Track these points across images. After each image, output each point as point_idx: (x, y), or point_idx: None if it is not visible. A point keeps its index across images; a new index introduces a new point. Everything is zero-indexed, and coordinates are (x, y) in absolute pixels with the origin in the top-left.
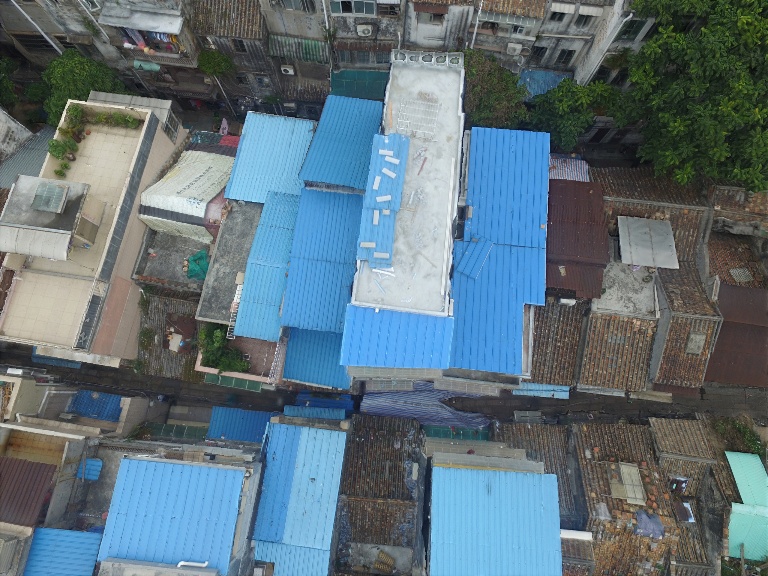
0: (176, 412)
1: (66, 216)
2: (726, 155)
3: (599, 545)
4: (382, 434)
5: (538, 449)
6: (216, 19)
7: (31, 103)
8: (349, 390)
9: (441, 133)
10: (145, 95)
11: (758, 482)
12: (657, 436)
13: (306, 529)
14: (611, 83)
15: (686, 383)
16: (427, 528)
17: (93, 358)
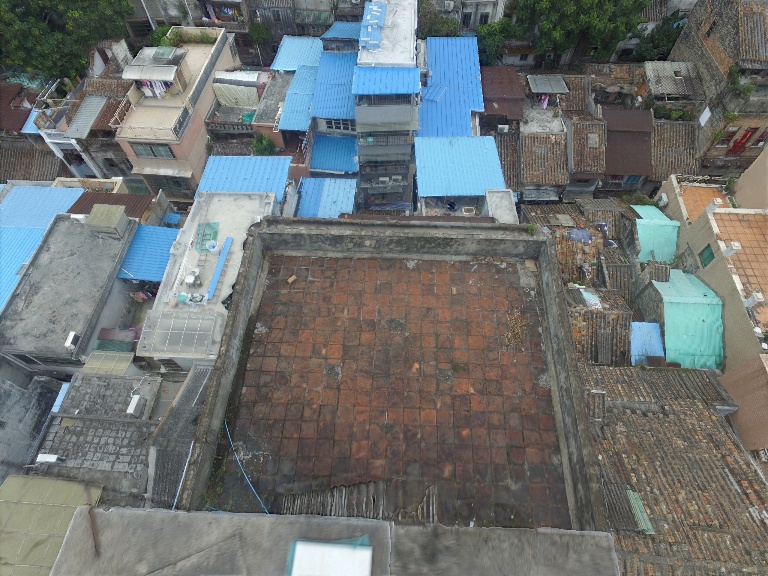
0: None
1: (174, 61)
2: (573, 7)
3: None
4: None
5: None
6: None
7: None
8: None
9: (405, 2)
10: None
11: (654, 213)
12: (581, 204)
13: None
14: None
15: (594, 169)
16: (416, 200)
17: (173, 172)
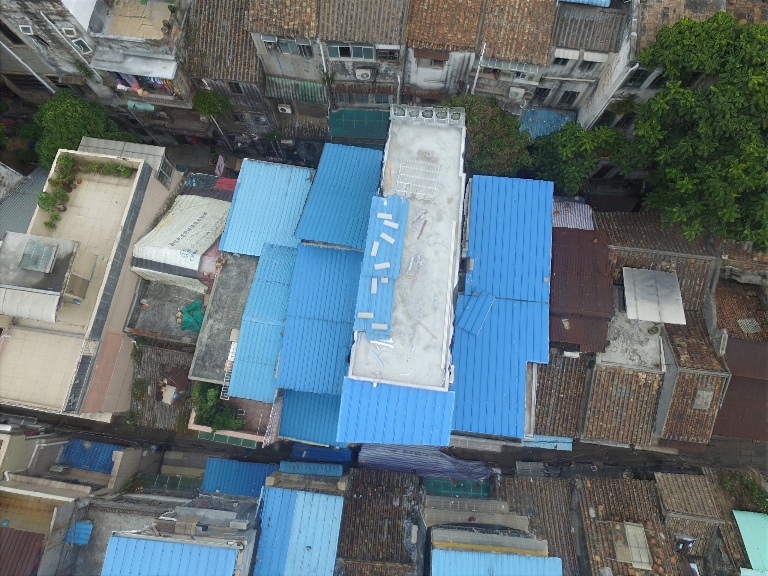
0: (170, 458)
1: (55, 275)
2: (736, 216)
3: None
4: (381, 490)
5: (541, 505)
6: (211, 62)
7: (23, 143)
8: None
9: (442, 194)
10: (140, 130)
11: (767, 545)
12: (663, 493)
13: None
14: (616, 126)
15: (693, 439)
16: None
17: (84, 413)
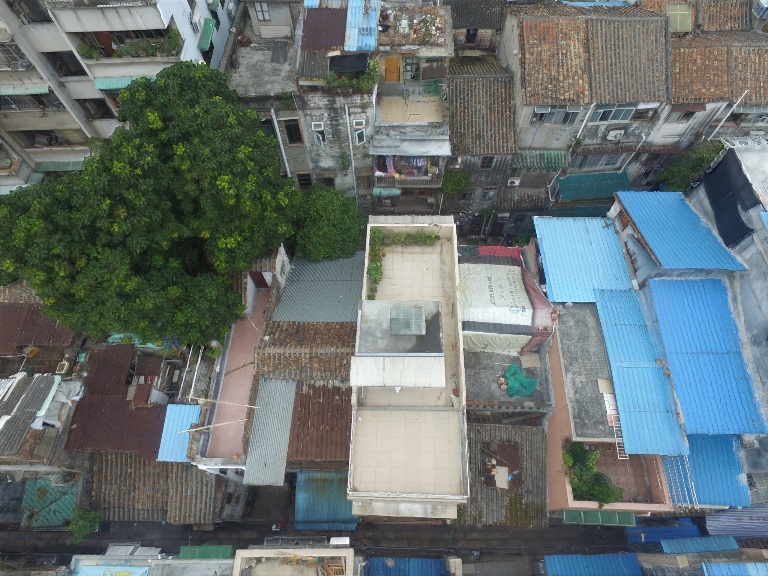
0: None
1: (428, 337)
2: None
3: None
4: None
5: None
6: (470, 141)
7: None
8: (705, 510)
9: None
10: None
11: None
12: None
13: None
14: None
15: None
16: None
17: (424, 510)
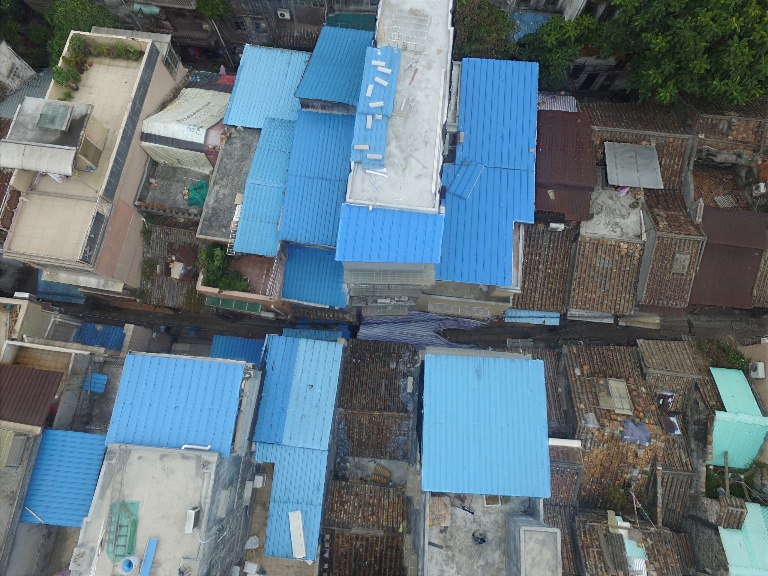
0: (178, 349)
1: (71, 134)
2: (705, 67)
3: (588, 453)
4: (378, 356)
5: None
6: None
7: (34, 47)
8: (346, 317)
9: (431, 46)
10: None
11: (741, 393)
12: (644, 355)
13: (305, 431)
14: (598, 20)
15: (672, 303)
16: (421, 423)
17: (97, 283)
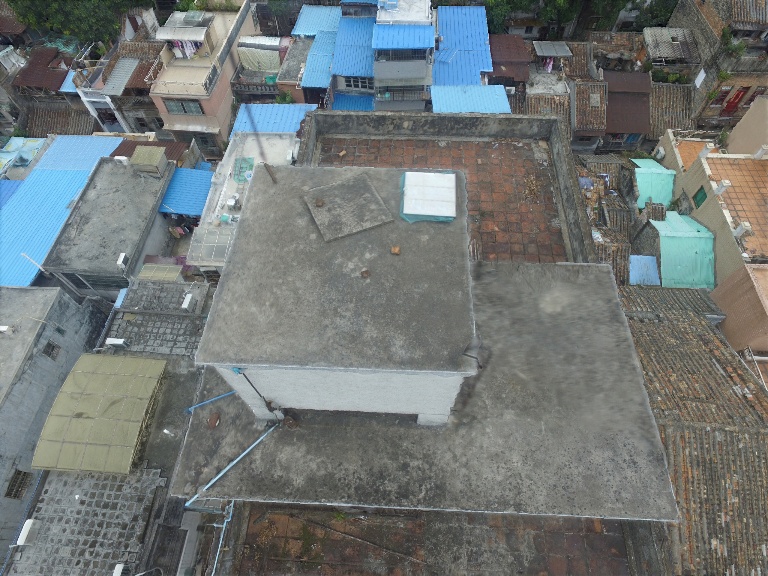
0: None
1: (203, 24)
2: None
3: None
4: None
5: None
6: None
7: None
8: None
9: None
10: None
11: (652, 164)
12: (584, 158)
13: None
14: None
15: (596, 127)
16: None
17: (201, 128)
